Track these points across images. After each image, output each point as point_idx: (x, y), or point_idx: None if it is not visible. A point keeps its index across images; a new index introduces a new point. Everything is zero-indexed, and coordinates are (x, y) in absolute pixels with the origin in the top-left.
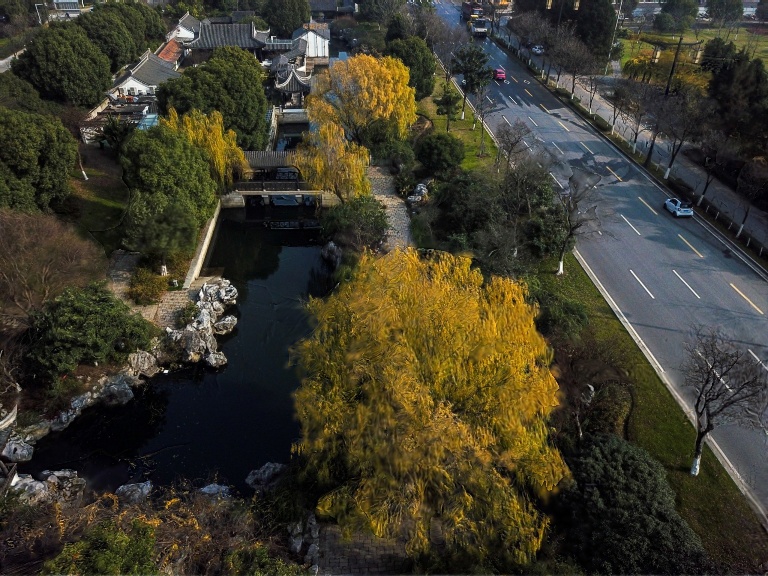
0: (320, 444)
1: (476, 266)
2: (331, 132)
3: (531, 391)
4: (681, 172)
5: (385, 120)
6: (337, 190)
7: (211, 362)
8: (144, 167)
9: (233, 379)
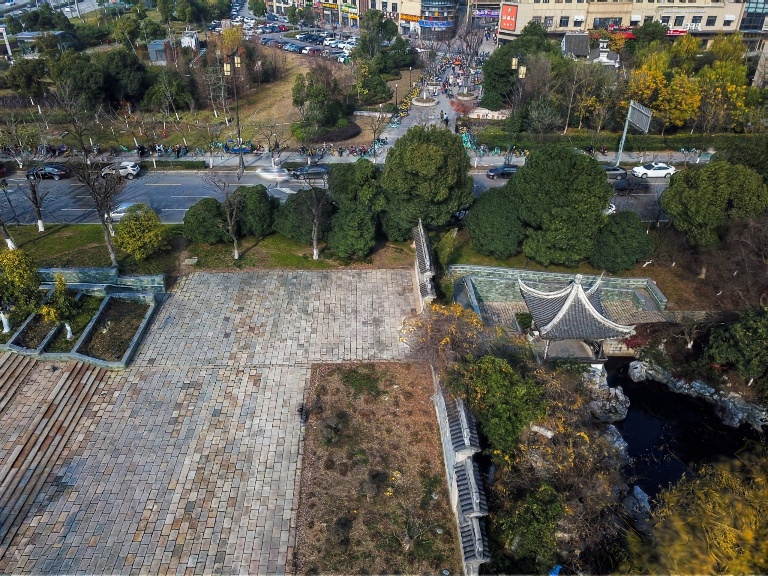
0: None
1: None
2: None
3: None
4: None
5: None
6: None
7: None
8: None
9: None
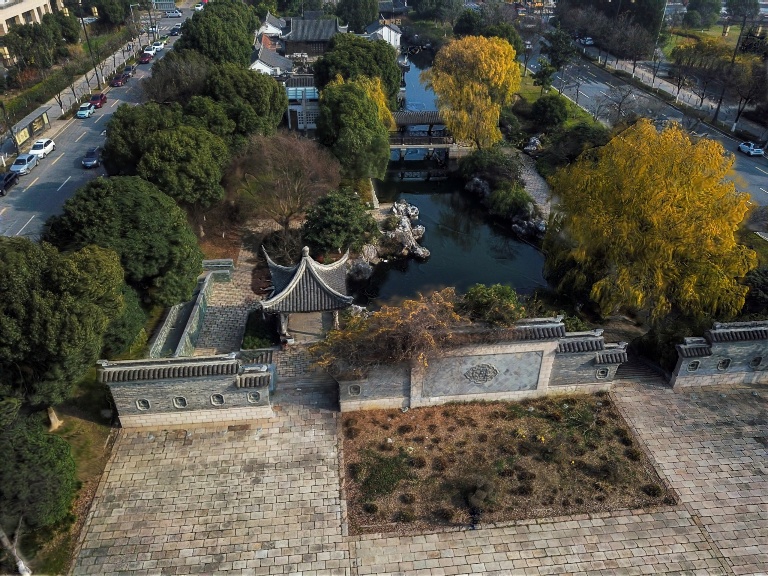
0: (583, 256)
1: (686, 136)
2: (474, 90)
3: (739, 203)
4: (743, 127)
5: (495, 89)
6: (476, 138)
7: (420, 253)
8: (344, 113)
9: (436, 267)
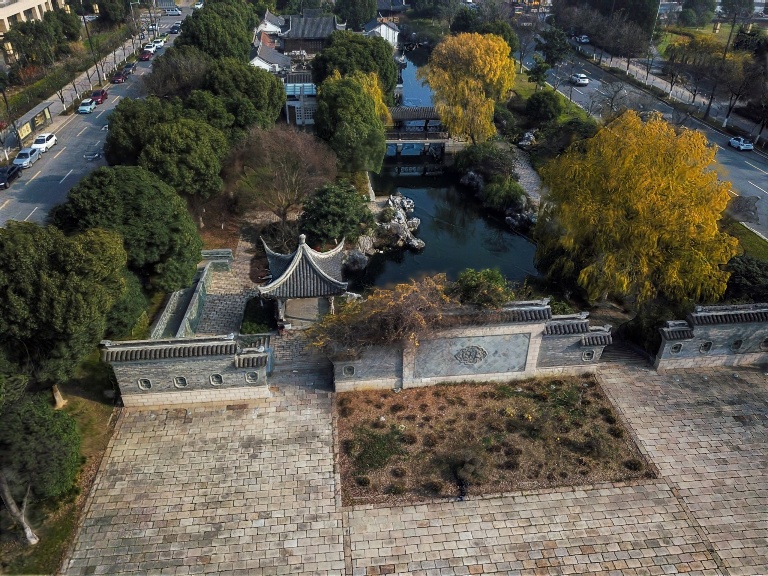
0: None
1: (671, 127)
2: (469, 86)
3: (721, 192)
4: None
5: (490, 85)
6: (471, 133)
7: (415, 244)
8: (341, 107)
9: (431, 258)
